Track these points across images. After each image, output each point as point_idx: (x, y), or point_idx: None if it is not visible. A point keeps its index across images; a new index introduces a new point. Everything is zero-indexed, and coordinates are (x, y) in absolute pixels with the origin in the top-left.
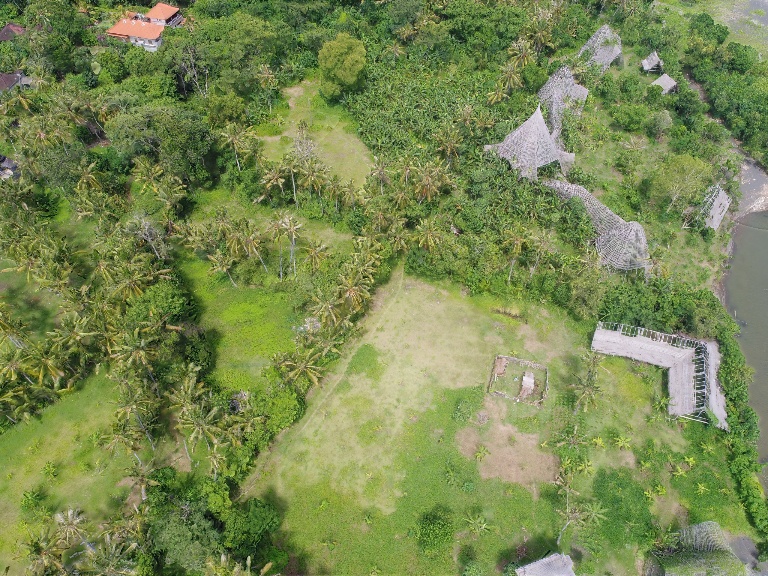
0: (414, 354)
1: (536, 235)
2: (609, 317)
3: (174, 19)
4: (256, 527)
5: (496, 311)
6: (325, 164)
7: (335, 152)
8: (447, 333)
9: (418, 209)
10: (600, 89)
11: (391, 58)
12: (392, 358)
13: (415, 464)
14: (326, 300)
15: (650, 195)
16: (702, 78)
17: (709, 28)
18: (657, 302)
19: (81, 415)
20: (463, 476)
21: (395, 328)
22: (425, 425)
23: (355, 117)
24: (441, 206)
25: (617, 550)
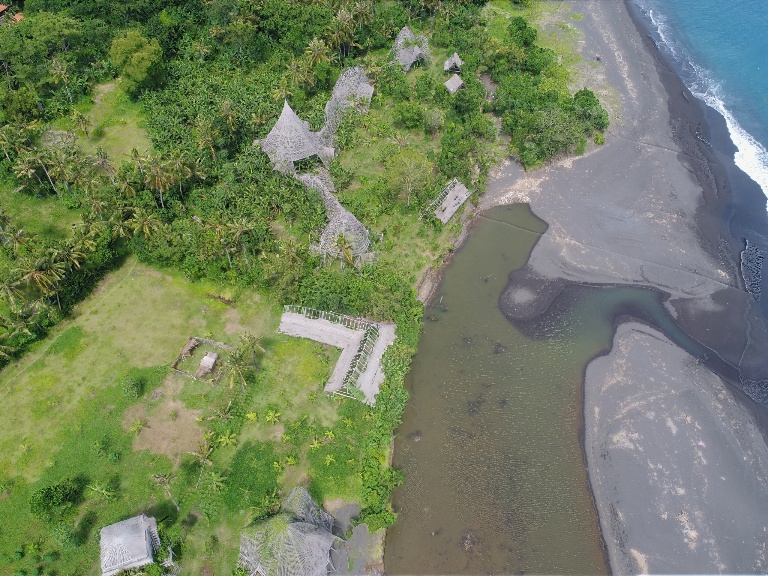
0: (117, 336)
1: (280, 225)
2: (305, 301)
3: (1, 17)
4: None
5: (213, 296)
6: None
7: (120, 146)
8: (156, 316)
9: (148, 199)
10: (392, 88)
11: (199, 56)
12: (94, 339)
13: (74, 437)
14: (2, 281)
15: None
16: (496, 78)
17: (522, 31)
18: (348, 287)
19: None
20: (114, 448)
21: (108, 311)
22: (99, 401)
23: (149, 112)
24: None
25: (231, 515)
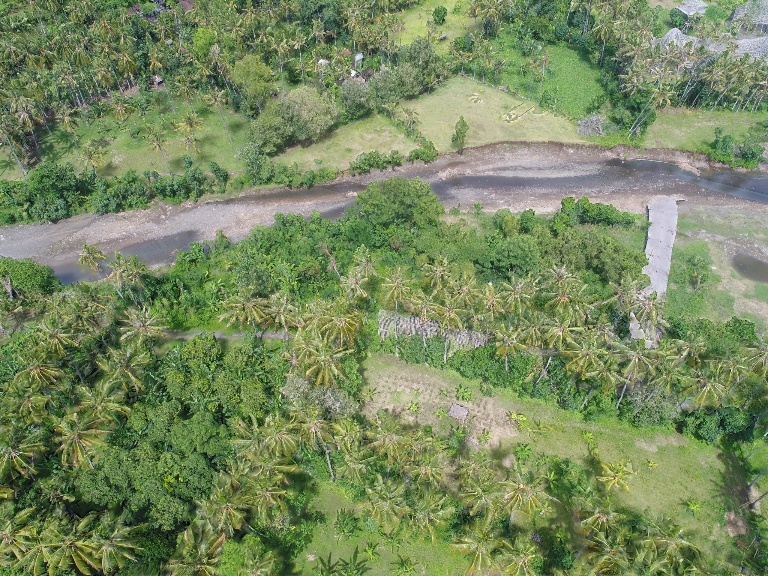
0: None
1: None
2: None
3: None
4: None
5: None
6: None
7: None
8: None
9: None
10: None
11: None
12: None
13: None
14: None
15: None
16: None
17: None
18: None
19: None
20: None
21: None
22: None
23: None
24: None
25: None
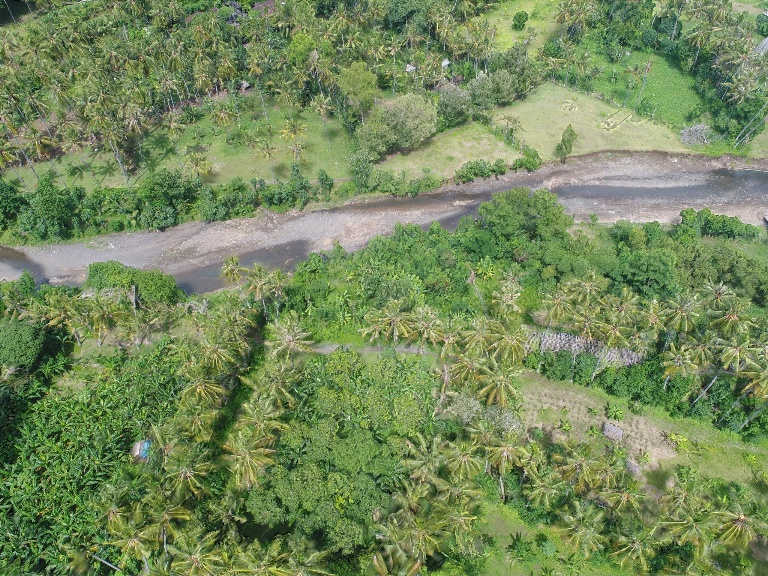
0: None
1: None
2: None
3: None
4: (651, 4)
5: None
6: None
7: None
8: None
9: None
10: None
11: None
12: None
13: None
14: None
15: None
16: None
17: None
18: None
19: (533, 0)
20: None
21: None
22: None
23: None
24: None
25: None
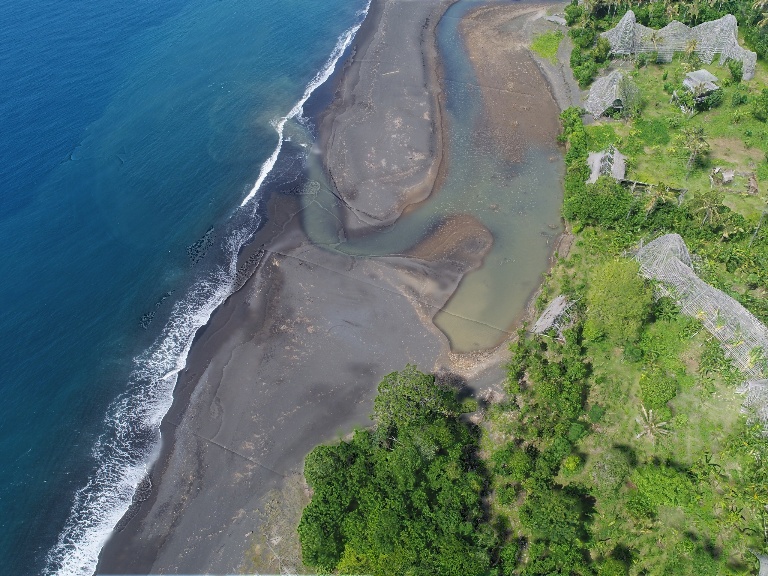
0: None
1: None
2: None
3: None
4: None
5: None
6: None
7: None
8: None
9: None
10: None
11: None
12: None
13: None
14: None
15: None
16: None
17: None
18: None
19: None
20: (754, 139)
21: None
22: None
23: None
24: None
25: None
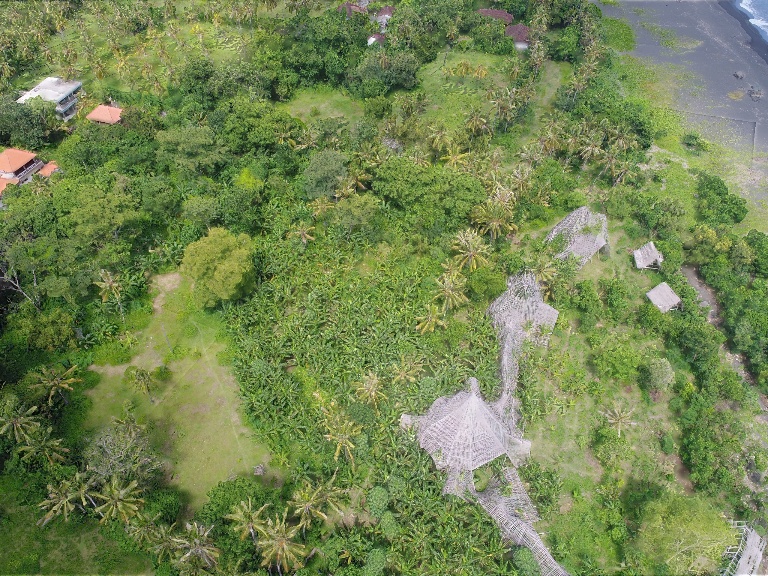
0: None
1: None
2: None
3: (28, 168)
4: None
5: None
6: (174, 429)
7: (195, 402)
8: None
9: None
10: (576, 303)
11: (298, 242)
12: None
13: None
14: None
15: (641, 522)
16: (715, 284)
17: (722, 198)
18: None
19: None
20: None
21: None
22: None
23: (234, 339)
24: (328, 523)
25: None
